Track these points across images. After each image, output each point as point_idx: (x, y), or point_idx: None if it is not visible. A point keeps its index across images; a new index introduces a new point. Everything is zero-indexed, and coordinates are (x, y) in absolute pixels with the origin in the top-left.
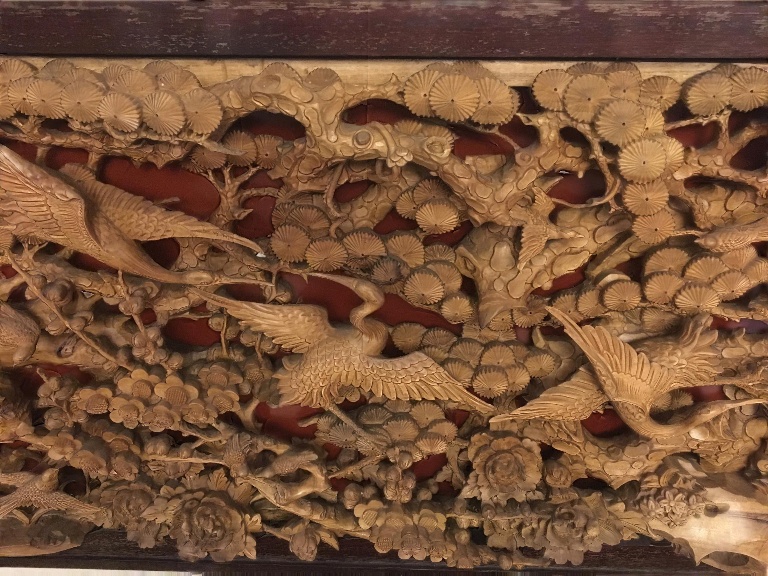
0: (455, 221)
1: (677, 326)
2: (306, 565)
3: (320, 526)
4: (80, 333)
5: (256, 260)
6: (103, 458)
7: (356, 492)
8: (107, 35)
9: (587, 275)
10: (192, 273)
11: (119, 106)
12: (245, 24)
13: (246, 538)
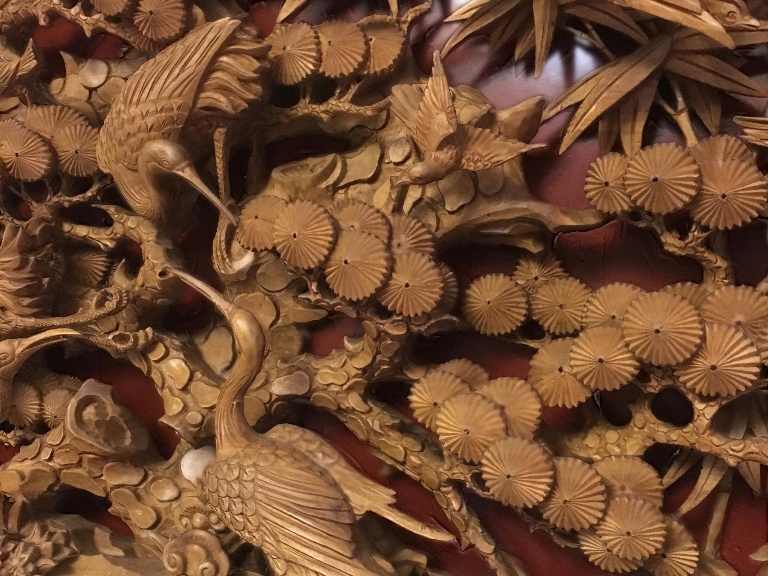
0: None
1: (65, 274)
2: None
3: None
4: None
5: None
6: None
7: None
8: None
9: None
10: None
11: None
12: None
13: None
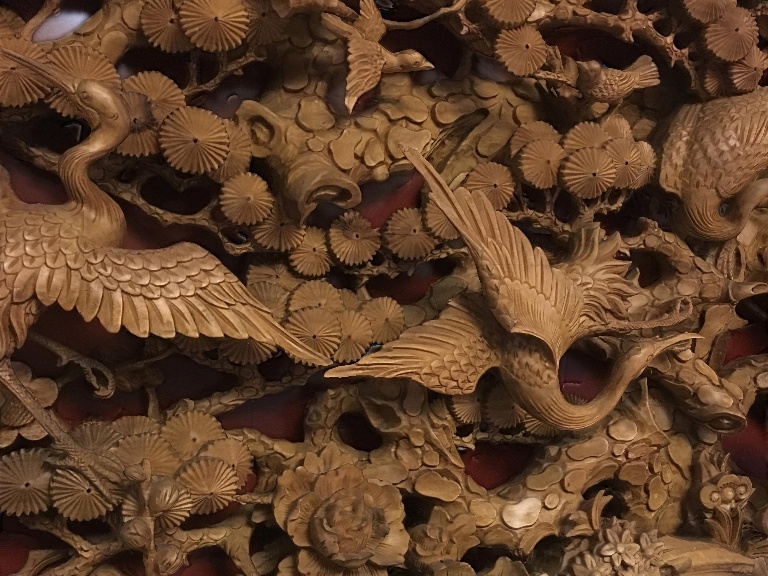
0: (245, 24)
1: None
2: None
3: None
4: None
5: None
6: None
7: None
8: None
9: (425, 198)
10: None
11: None
12: None
13: None
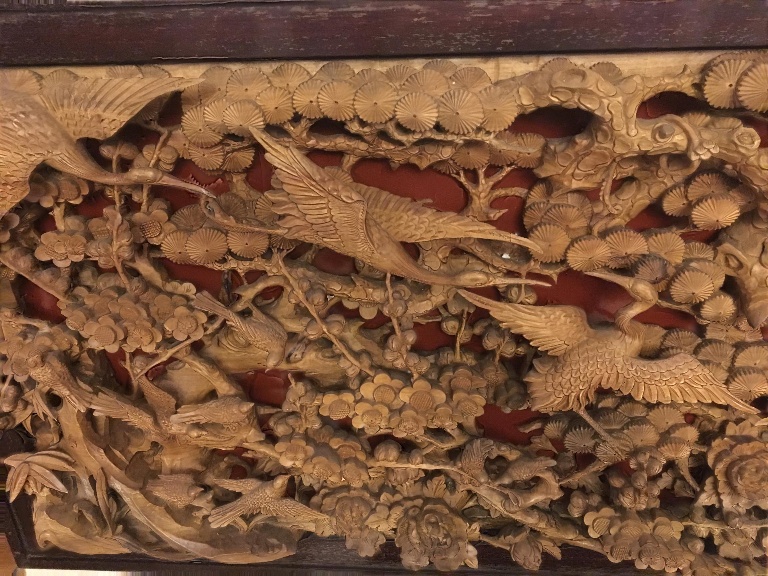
0: (736, 216)
1: None
2: (517, 575)
3: (540, 535)
4: (334, 337)
5: (505, 261)
6: (338, 464)
7: (584, 499)
8: (391, 35)
9: None
10: (467, 274)
11: (420, 105)
12: (534, 19)
13: (467, 547)
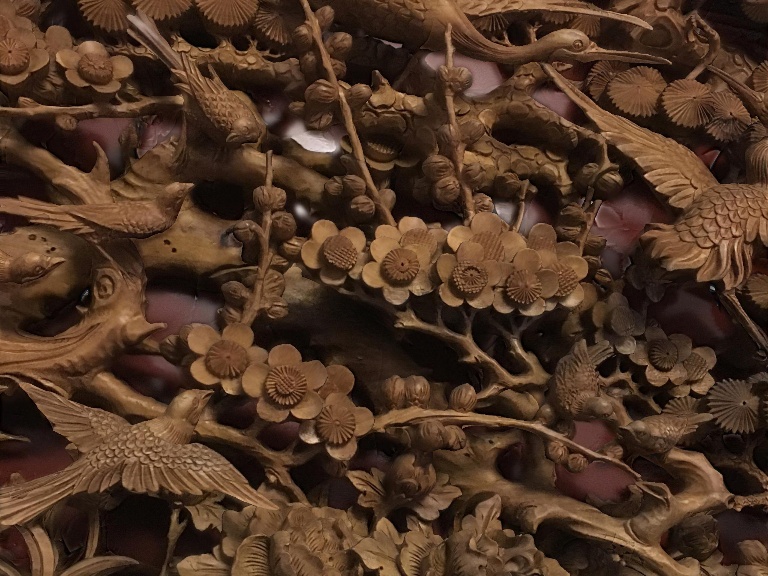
0: None
1: None
2: None
3: None
4: (351, 117)
5: None
6: (323, 366)
7: None
8: None
9: None
10: (563, 29)
11: None
12: None
13: None
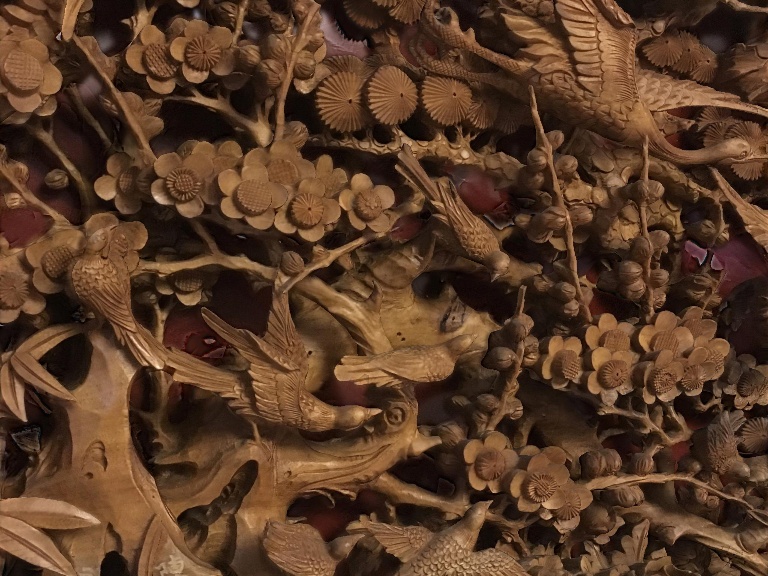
0: None
1: None
2: None
3: None
4: None
5: None
6: (565, 467)
7: None
8: None
9: None
10: (733, 140)
11: None
12: None
13: None
